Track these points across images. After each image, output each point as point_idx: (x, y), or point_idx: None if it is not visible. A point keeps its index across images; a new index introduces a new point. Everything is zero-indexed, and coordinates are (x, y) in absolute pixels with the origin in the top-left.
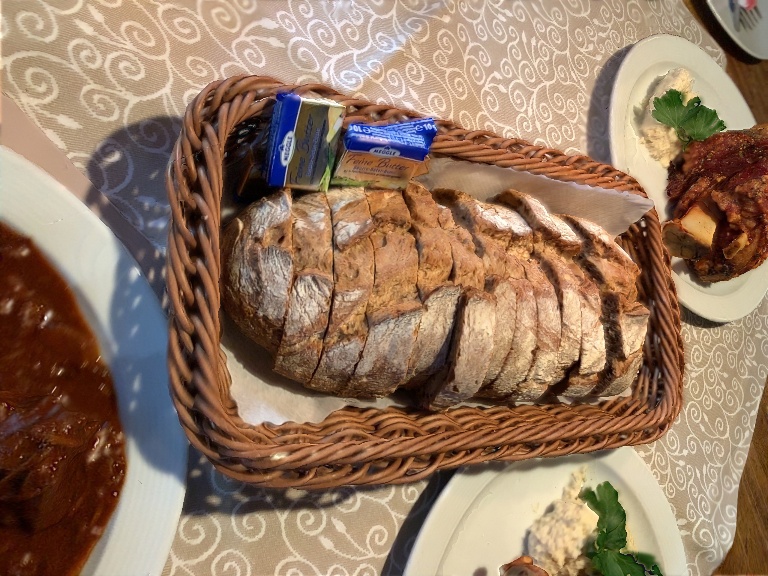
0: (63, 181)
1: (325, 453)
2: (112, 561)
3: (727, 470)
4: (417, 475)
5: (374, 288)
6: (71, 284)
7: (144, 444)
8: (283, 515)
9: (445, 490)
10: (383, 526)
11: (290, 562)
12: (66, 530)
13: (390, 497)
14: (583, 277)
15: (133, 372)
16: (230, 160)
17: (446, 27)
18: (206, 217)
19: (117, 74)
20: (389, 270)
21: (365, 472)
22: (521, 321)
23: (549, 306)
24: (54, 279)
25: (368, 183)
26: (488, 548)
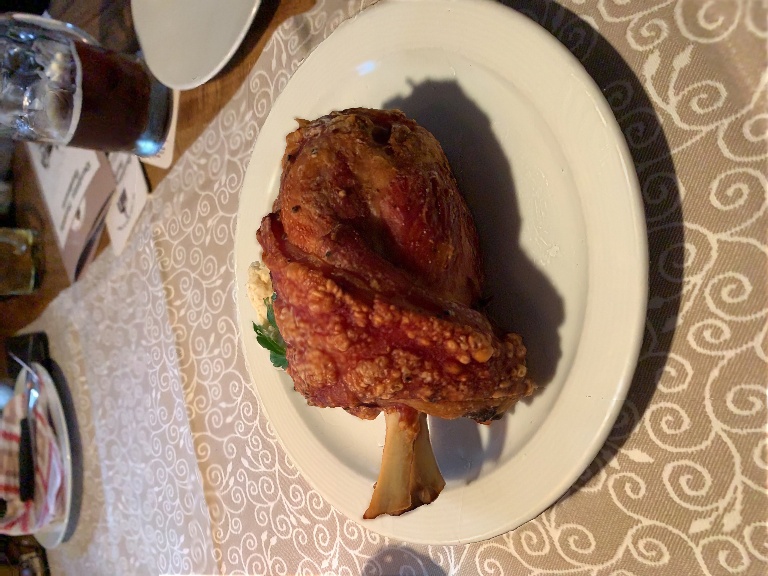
0: None
1: None
2: None
3: None
4: None
5: None
6: None
7: None
8: None
9: None
10: None
11: None
12: None
13: None
14: None
15: None
16: None
17: (228, 574)
18: None
19: None
20: None
21: None
22: None
23: None
24: None
25: None
26: None
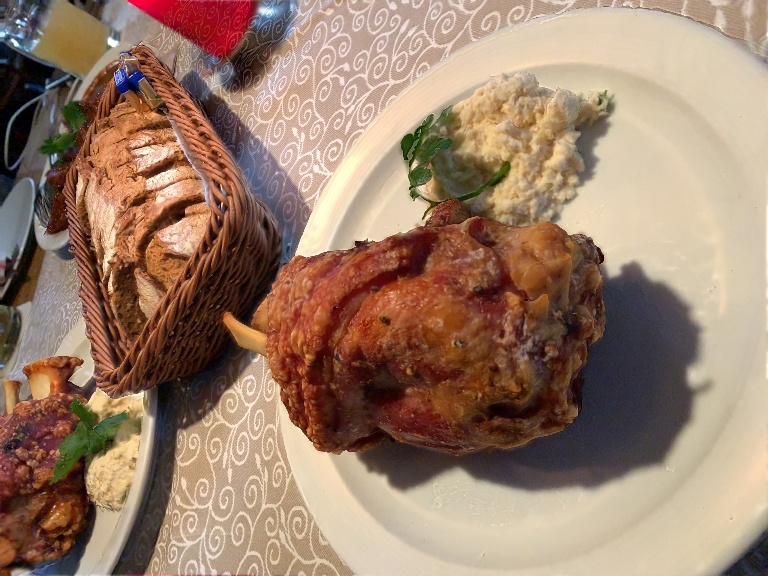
0: None
1: None
2: None
3: None
4: None
5: None
6: None
7: None
8: None
9: None
10: None
11: None
12: None
13: None
14: None
15: None
16: None
17: (325, 19)
18: (100, 100)
19: None
20: None
21: None
22: None
23: (103, 208)
24: None
25: None
26: None
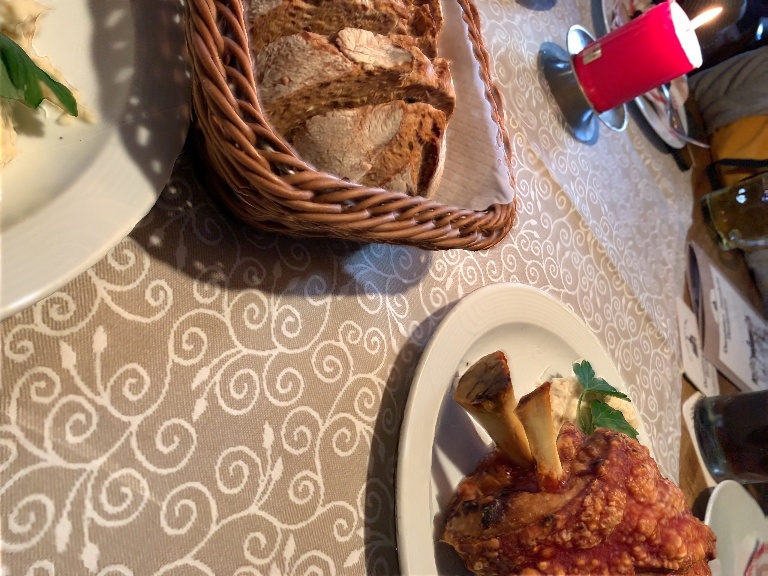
0: None
1: None
2: None
3: None
4: None
5: None
6: None
7: None
8: None
9: None
10: None
11: None
12: None
13: None
14: None
15: None
16: None
17: None
18: None
19: None
20: None
21: None
22: None
23: None
24: None
25: None
26: None
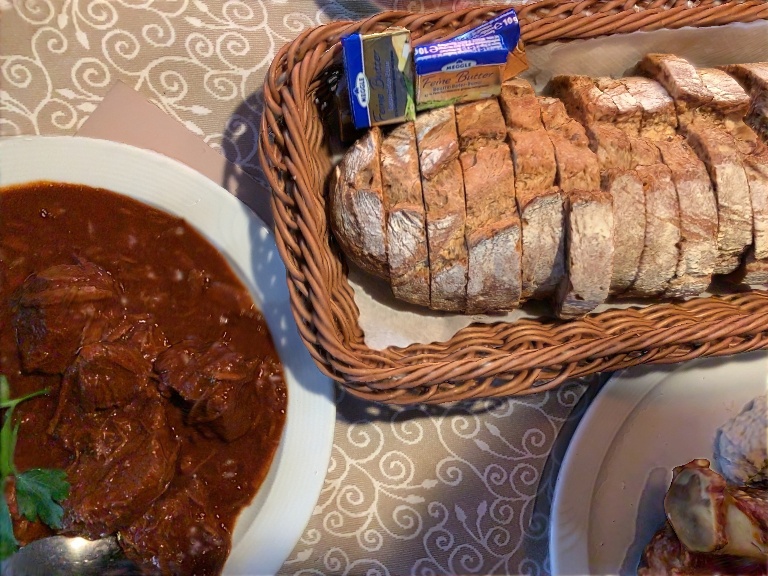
0: (205, 163)
1: (440, 372)
2: (288, 462)
3: None
4: (544, 386)
5: (468, 210)
6: (220, 250)
7: (297, 371)
8: (438, 421)
9: (600, 394)
10: (539, 429)
11: (449, 461)
12: (253, 439)
13: (544, 402)
14: (756, 141)
15: (279, 314)
16: (331, 108)
17: None
18: (295, 177)
19: (227, 55)
20: (479, 190)
21: (487, 386)
22: (654, 214)
23: (696, 189)
24: (207, 248)
25: (456, 100)
26: (667, 448)
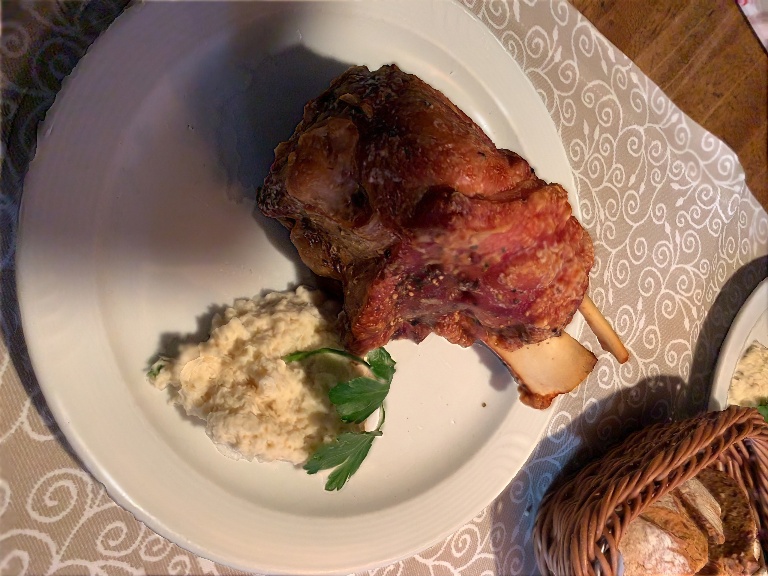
0: None
1: None
2: None
3: (670, 134)
4: None
5: None
6: None
7: None
8: None
9: None
10: None
11: None
12: None
13: None
14: None
15: None
16: None
17: None
18: None
19: None
20: None
21: None
22: None
23: None
24: None
25: None
26: None
